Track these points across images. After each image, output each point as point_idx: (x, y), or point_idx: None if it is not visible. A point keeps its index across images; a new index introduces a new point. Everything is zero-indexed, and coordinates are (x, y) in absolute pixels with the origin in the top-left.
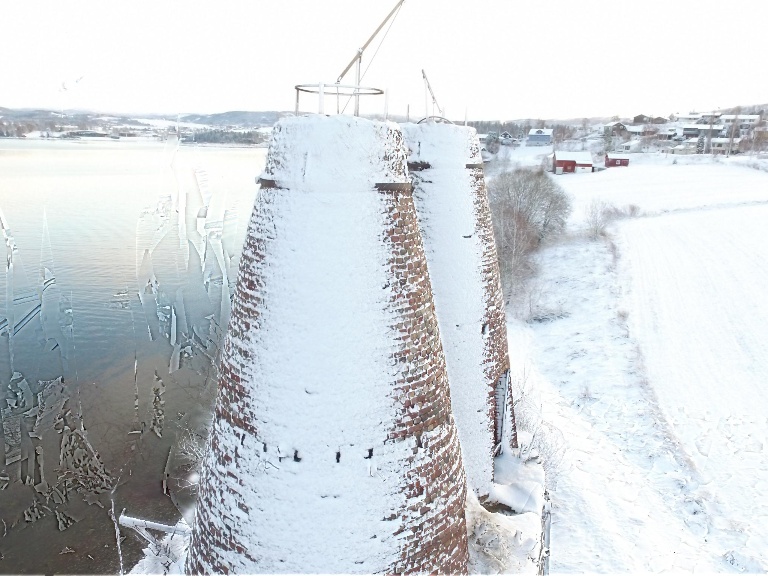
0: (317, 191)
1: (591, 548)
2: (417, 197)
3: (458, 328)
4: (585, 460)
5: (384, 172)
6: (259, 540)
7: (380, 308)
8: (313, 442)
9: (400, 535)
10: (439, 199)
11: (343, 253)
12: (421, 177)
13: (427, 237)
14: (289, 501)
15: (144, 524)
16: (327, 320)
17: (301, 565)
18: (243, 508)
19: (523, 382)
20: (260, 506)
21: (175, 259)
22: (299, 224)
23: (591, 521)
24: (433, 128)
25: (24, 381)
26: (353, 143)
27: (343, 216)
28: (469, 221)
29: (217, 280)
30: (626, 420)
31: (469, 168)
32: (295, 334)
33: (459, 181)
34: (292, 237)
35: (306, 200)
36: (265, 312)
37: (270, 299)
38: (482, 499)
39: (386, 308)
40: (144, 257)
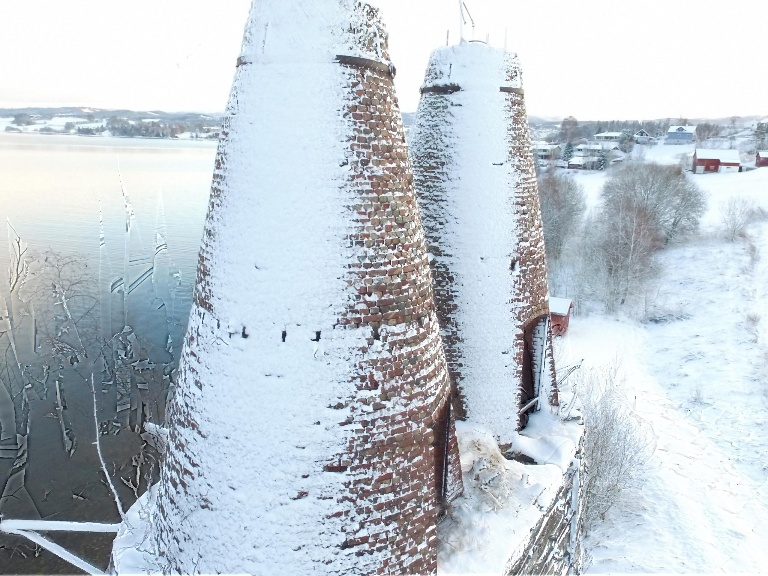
0: (275, 62)
1: (677, 554)
2: (445, 122)
3: (483, 261)
4: (685, 465)
5: (348, 45)
6: (208, 416)
7: (335, 186)
8: (260, 318)
9: (347, 426)
10: (468, 123)
11: (297, 125)
12: (450, 100)
13: (454, 163)
14: (235, 377)
15: (165, 432)
16: (278, 194)
17: (243, 443)
18: (198, 385)
19: (614, 371)
20: (211, 382)
21: None
22: (257, 96)
23: (681, 527)
24: (465, 48)
25: (133, 334)
26: (313, 11)
27: (299, 87)
28: (500, 148)
29: None
30: (741, 428)
31: (504, 91)
32: (249, 208)
33: (491, 104)
34: (250, 110)
35: (265, 72)
36: (225, 188)
37: (229, 175)
38: (504, 448)
39: (343, 187)
40: None
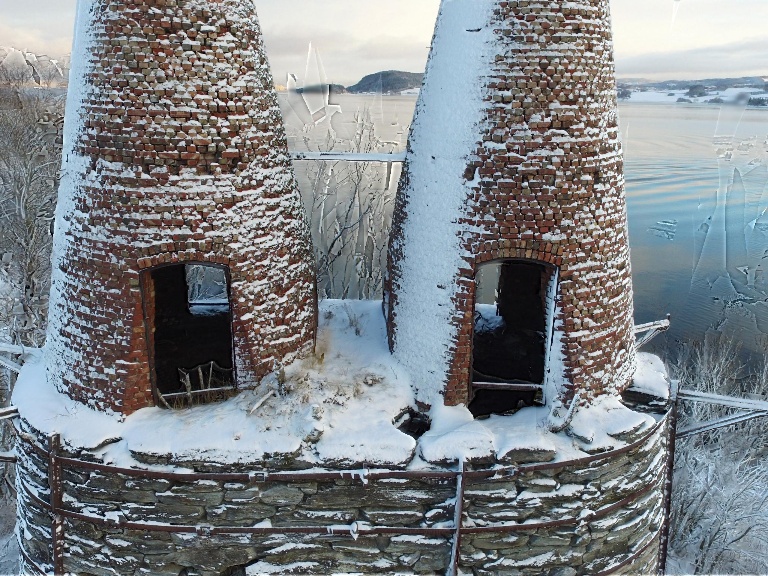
0: None
1: None
2: None
3: (434, 161)
4: None
5: None
6: None
7: (85, 31)
8: None
9: None
10: None
11: None
12: None
13: None
14: None
15: None
16: None
17: None
18: None
19: None
20: None
21: (750, 199)
22: None
23: None
24: None
25: None
26: None
27: None
28: (481, 6)
29: (766, 226)
30: None
31: None
32: None
33: None
34: None
35: None
36: None
37: None
38: (421, 406)
39: None
40: (714, 191)
